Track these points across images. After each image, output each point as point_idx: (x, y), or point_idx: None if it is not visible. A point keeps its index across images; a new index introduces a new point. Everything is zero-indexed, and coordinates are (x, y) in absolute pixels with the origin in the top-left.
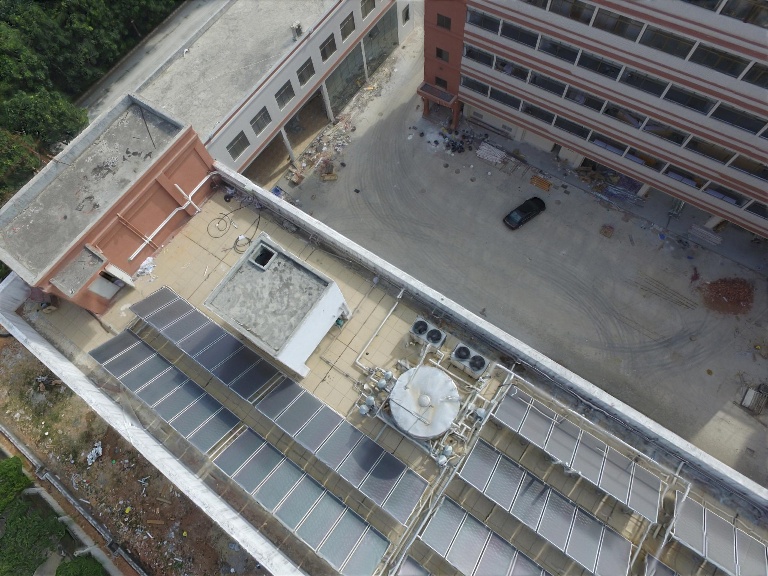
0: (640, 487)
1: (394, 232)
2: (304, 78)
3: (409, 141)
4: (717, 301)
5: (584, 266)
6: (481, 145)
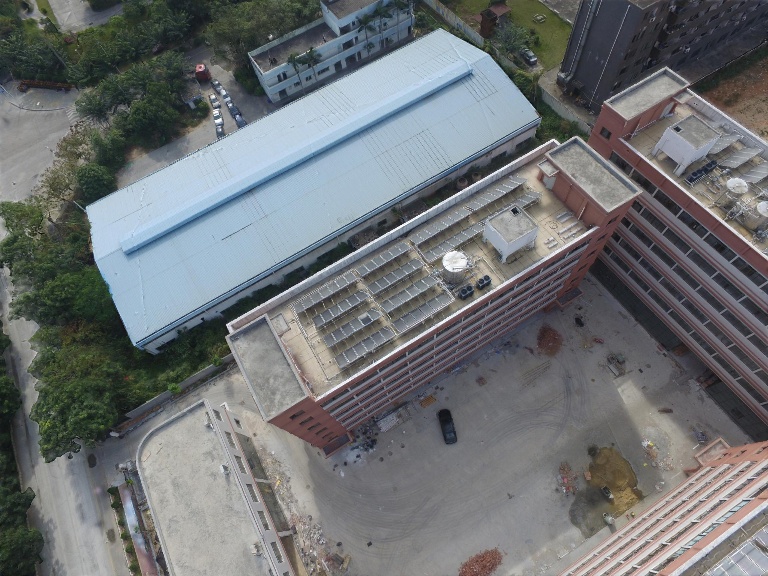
0: (753, 556)
1: (420, 531)
2: (279, 556)
3: (345, 477)
4: (551, 349)
5: (500, 410)
6: (378, 425)
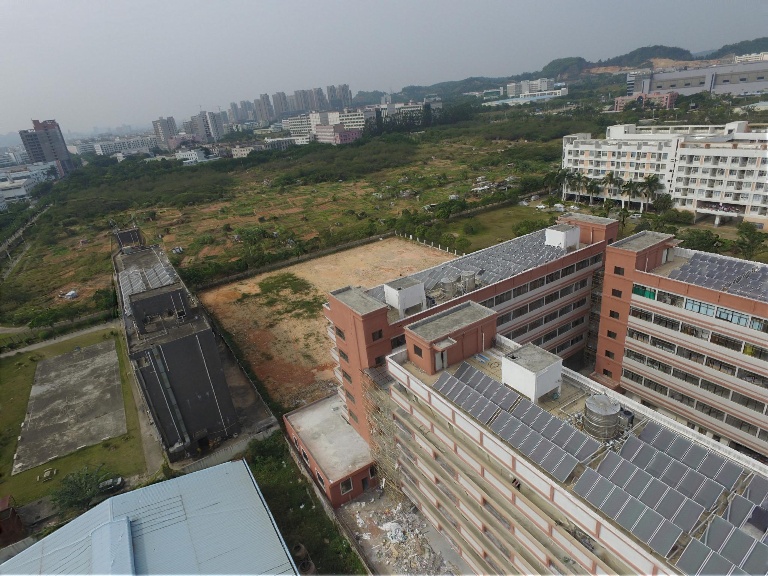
0: None
1: None
2: None
3: None
4: None
5: None
6: None
